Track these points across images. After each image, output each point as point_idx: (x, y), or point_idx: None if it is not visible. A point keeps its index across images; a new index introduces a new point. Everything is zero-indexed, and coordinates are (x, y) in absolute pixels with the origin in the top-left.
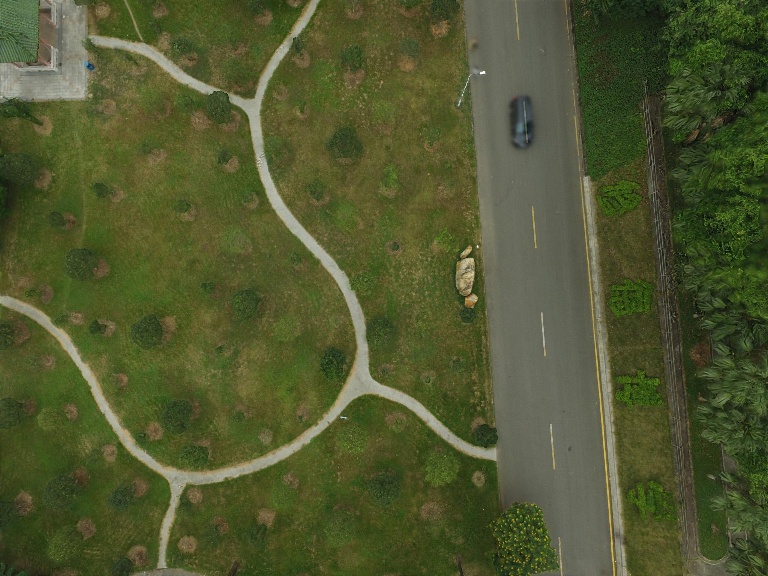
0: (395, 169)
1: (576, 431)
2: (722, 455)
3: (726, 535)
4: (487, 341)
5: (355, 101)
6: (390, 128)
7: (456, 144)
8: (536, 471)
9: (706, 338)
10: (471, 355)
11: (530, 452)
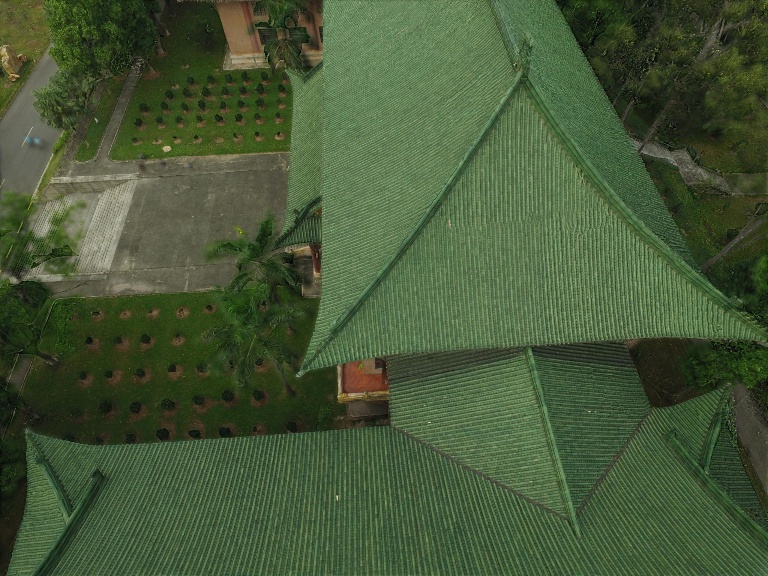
0: (7, 37)
1: (47, 130)
2: (112, 116)
3: (96, 150)
4: (15, 94)
5: (3, 17)
6: (15, 24)
7: (47, 29)
8: (9, 148)
9: (126, 72)
10: (1, 99)
11: (11, 140)
